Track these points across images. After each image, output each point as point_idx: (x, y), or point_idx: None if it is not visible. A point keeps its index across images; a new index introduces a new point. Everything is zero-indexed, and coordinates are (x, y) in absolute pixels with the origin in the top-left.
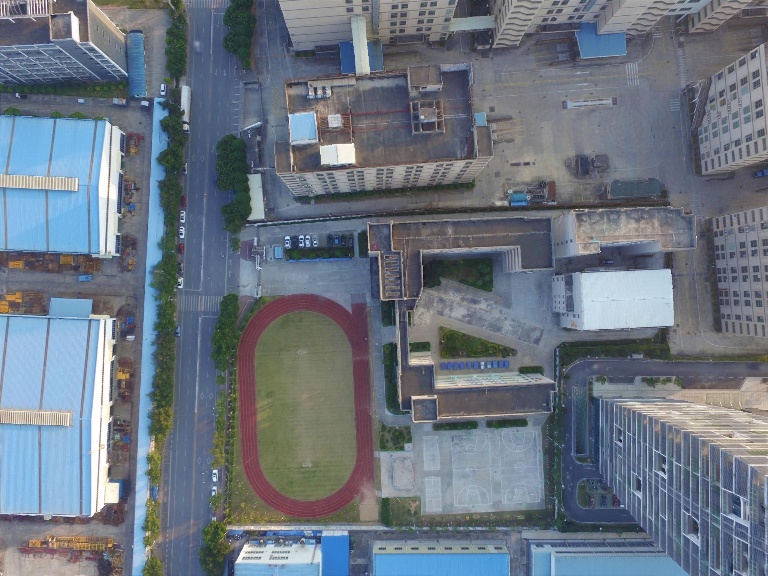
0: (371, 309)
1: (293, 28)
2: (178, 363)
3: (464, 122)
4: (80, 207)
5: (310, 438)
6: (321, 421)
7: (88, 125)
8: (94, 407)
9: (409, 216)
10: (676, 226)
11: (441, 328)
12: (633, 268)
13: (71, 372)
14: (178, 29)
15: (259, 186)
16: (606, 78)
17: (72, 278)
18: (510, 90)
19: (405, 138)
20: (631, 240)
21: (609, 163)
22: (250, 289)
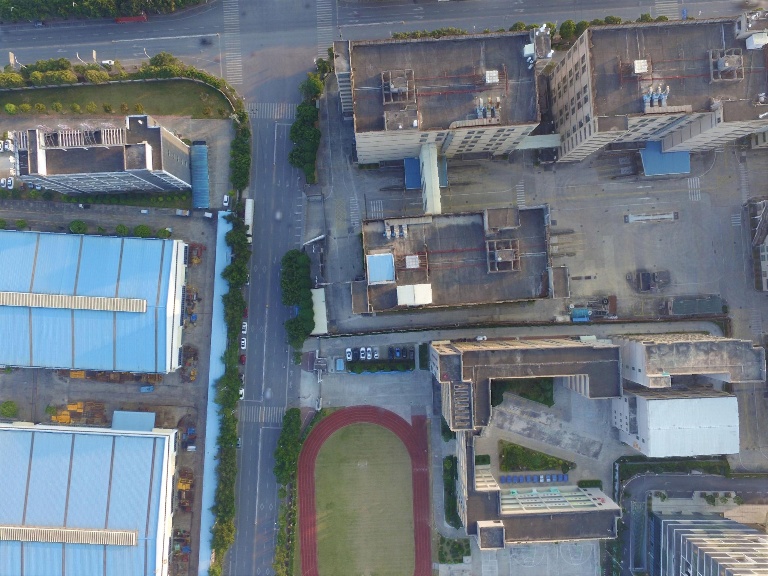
0: (431, 421)
1: (363, 152)
2: (238, 474)
3: (539, 260)
4: (147, 328)
5: (369, 549)
6: (380, 532)
7: (156, 245)
8: (159, 526)
9: (470, 329)
10: (745, 358)
11: (501, 442)
12: (692, 383)
13: (136, 491)
14: (243, 143)
15: (322, 301)
16: (668, 192)
17: (133, 388)
18: (572, 204)
19: (480, 276)
20: (700, 373)
21: (670, 278)
22: (311, 400)
